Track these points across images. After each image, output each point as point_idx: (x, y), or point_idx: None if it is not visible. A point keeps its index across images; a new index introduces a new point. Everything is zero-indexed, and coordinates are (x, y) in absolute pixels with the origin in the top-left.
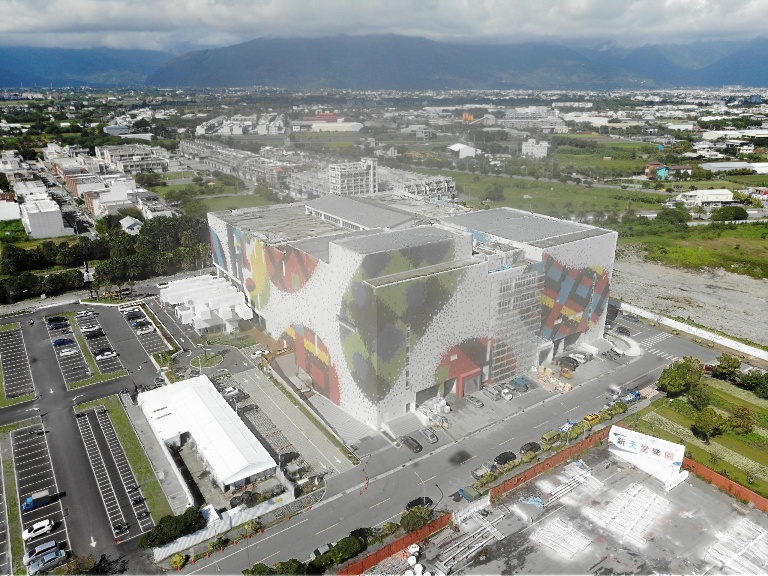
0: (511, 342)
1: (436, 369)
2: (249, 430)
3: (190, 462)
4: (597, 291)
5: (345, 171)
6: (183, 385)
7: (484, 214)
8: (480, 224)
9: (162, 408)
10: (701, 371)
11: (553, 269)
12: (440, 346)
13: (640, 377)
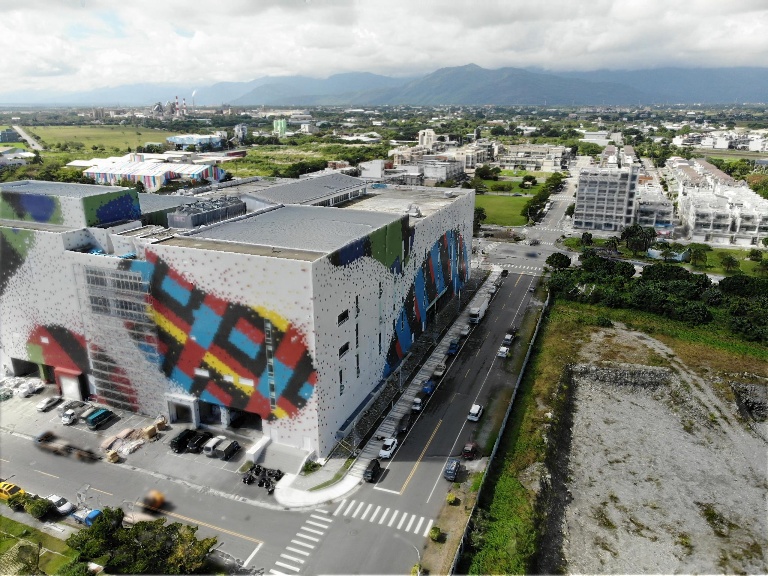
0: (123, 362)
1: (27, 342)
2: None
3: None
4: (282, 358)
5: (586, 177)
6: None
7: (343, 212)
8: (289, 218)
9: None
10: (179, 571)
11: (173, 282)
12: (25, 317)
13: (186, 519)
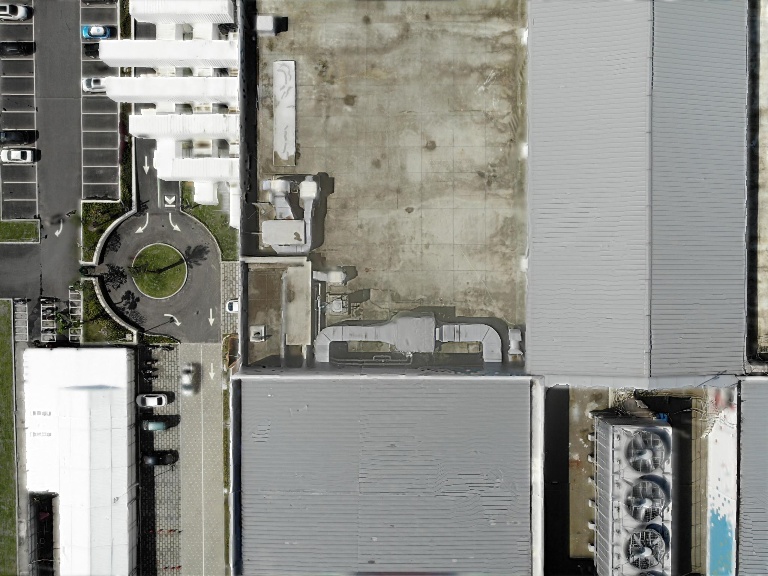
0: None
1: None
2: (126, 543)
3: (58, 526)
4: None
5: None
6: (87, 364)
7: None
8: None
9: (44, 412)
10: None
11: None
12: None
13: None
